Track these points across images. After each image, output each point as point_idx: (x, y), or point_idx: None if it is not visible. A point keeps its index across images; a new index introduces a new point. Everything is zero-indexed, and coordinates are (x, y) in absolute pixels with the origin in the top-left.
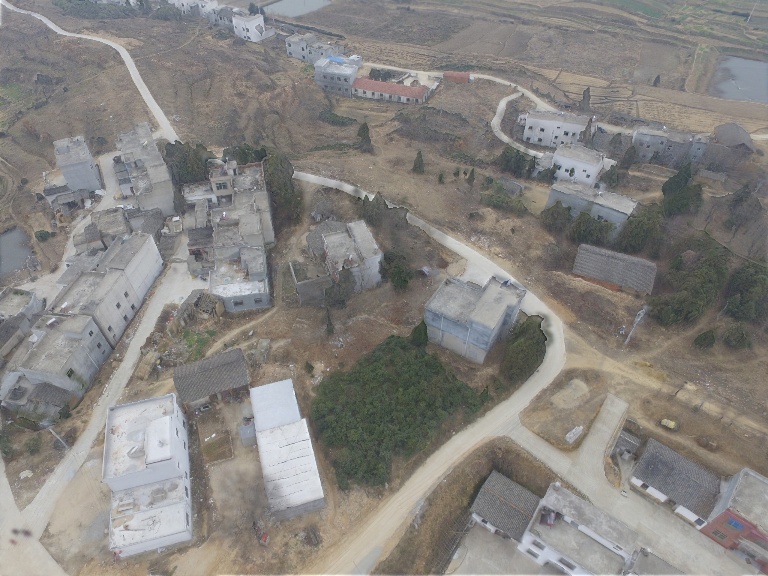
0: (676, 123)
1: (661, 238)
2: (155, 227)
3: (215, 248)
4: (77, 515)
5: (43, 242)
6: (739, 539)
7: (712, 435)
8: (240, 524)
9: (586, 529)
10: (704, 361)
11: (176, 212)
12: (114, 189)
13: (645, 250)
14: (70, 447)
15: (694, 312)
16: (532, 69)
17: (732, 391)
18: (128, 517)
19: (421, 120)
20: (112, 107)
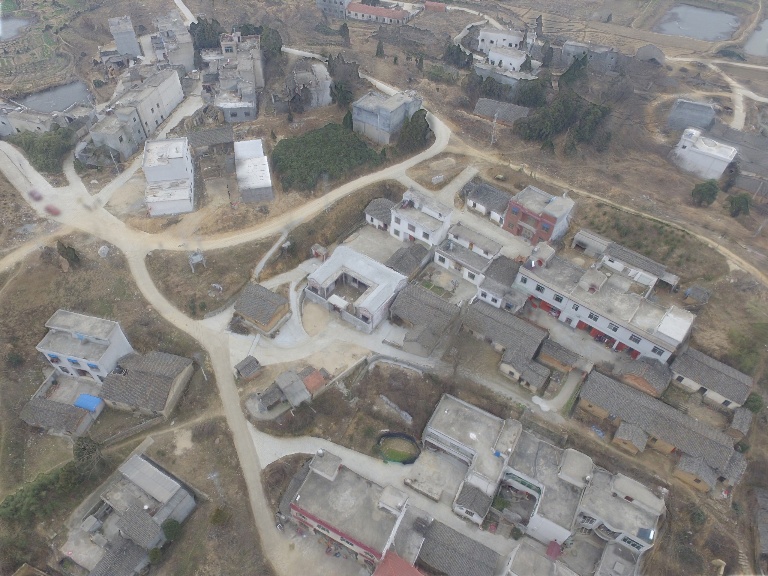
0: None
1: (542, 94)
2: (180, 75)
3: (220, 79)
4: (125, 199)
5: (99, 88)
6: (518, 222)
7: (523, 181)
8: (221, 203)
9: (425, 209)
10: (546, 162)
11: (195, 68)
12: (151, 56)
13: (532, 105)
14: (121, 173)
15: (544, 130)
16: (506, 7)
17: (557, 175)
18: (156, 192)
19: (396, 32)
20: (151, 7)
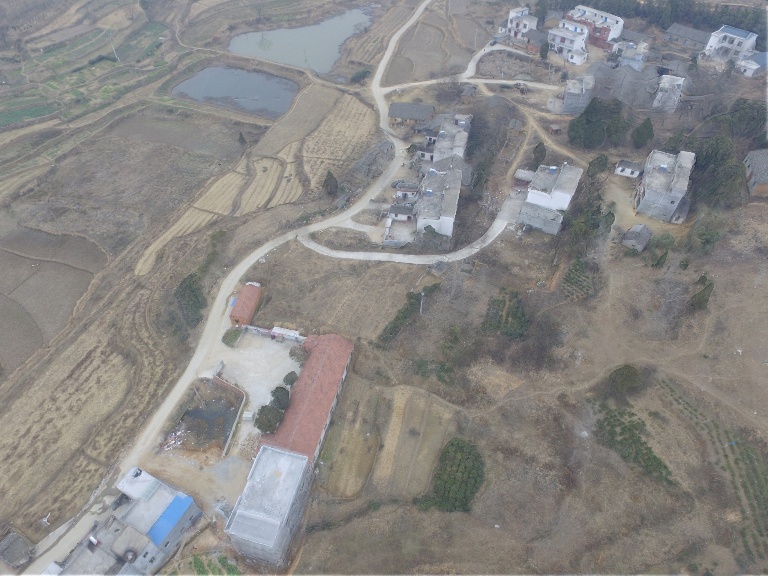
0: (355, 140)
1: None
2: None
3: None
4: None
5: None
6: None
7: None
8: None
9: None
10: None
11: None
12: None
13: None
14: None
15: None
16: (177, 232)
17: None
18: None
19: (460, 333)
20: None
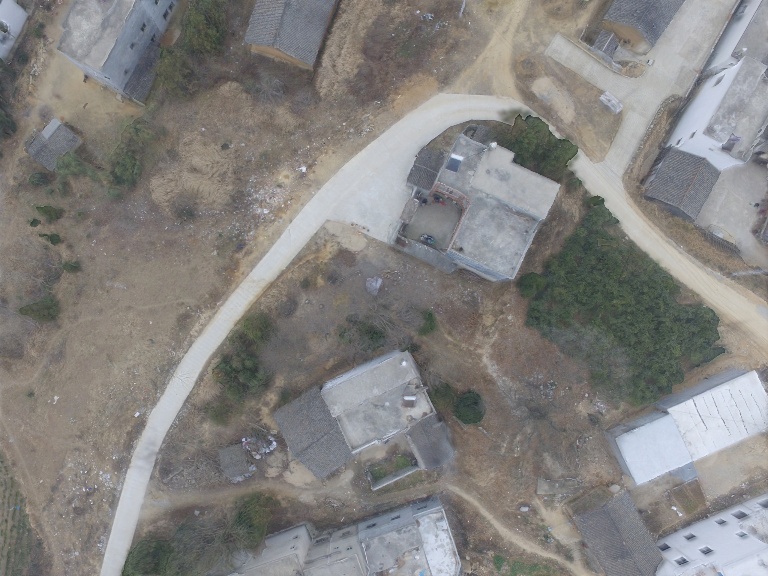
0: None
1: None
2: None
3: None
4: None
5: None
6: None
7: None
8: (762, 449)
9: None
10: None
11: None
12: None
13: None
14: None
15: None
16: None
17: None
18: None
19: None
20: None
